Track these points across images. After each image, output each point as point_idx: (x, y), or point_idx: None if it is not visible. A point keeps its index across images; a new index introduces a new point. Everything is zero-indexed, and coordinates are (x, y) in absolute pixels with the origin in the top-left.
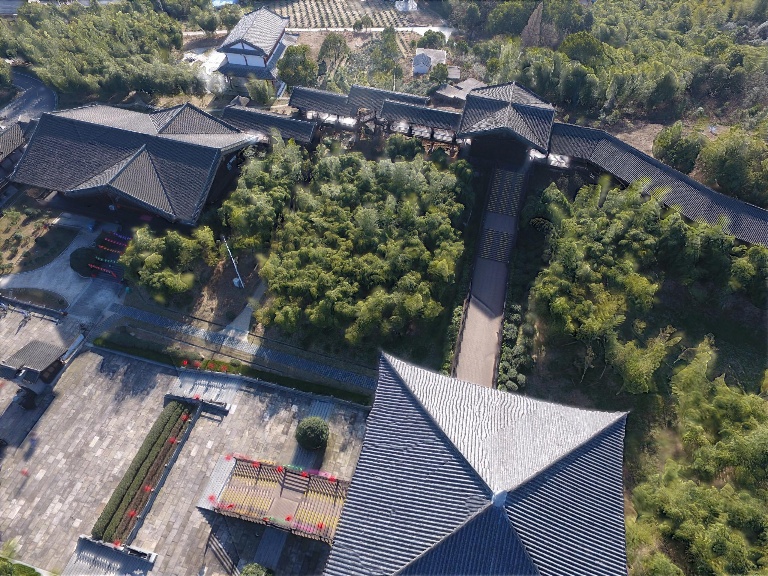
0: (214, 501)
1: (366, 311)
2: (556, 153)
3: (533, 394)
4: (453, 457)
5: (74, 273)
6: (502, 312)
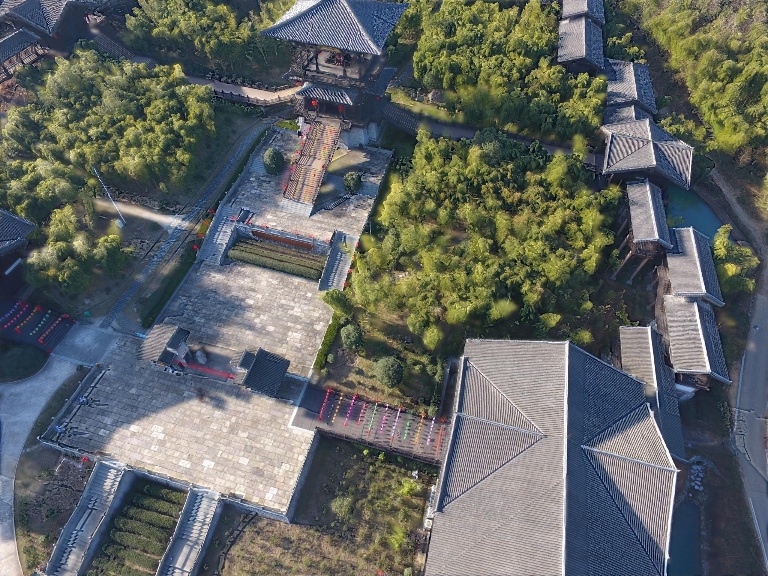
0: (308, 206)
1: (200, 109)
2: (94, 9)
3: (268, 85)
4: (320, 6)
5: (31, 381)
6: (212, 80)
